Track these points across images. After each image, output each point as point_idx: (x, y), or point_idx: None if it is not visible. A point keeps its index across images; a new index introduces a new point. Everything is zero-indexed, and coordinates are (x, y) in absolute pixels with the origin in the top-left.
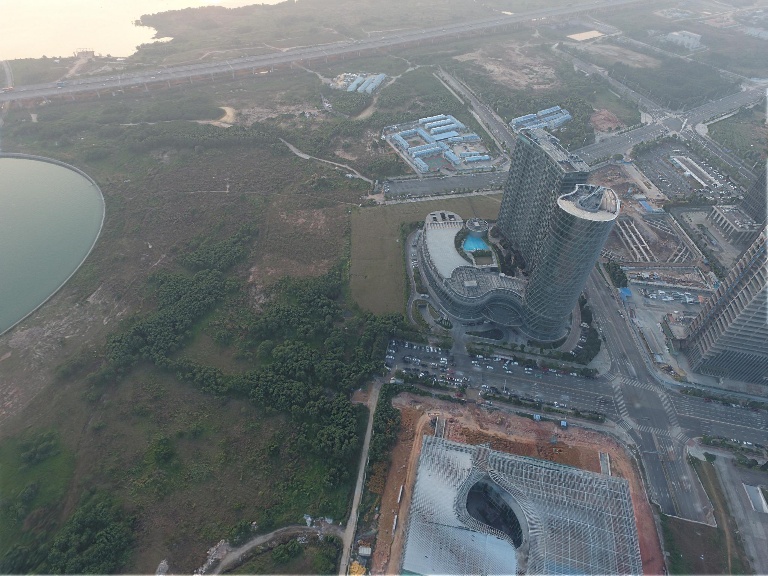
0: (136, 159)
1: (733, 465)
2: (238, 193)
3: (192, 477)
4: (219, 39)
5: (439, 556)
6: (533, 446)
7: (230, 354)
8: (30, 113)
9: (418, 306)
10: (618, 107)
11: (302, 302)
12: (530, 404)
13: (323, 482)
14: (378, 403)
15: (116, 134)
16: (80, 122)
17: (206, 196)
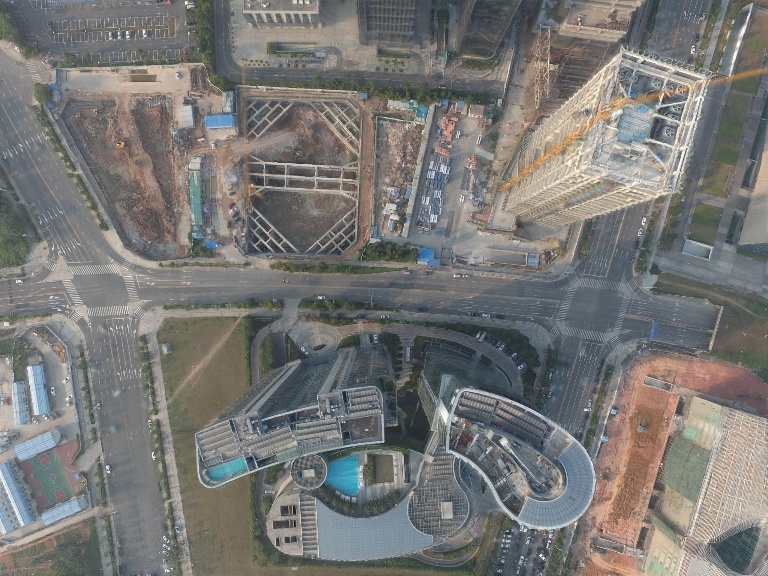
0: None
1: (664, 251)
2: None
3: None
4: None
5: None
6: (634, 451)
7: None
8: None
9: (433, 549)
10: None
11: None
12: (588, 441)
13: None
14: None
15: None
16: None
17: None
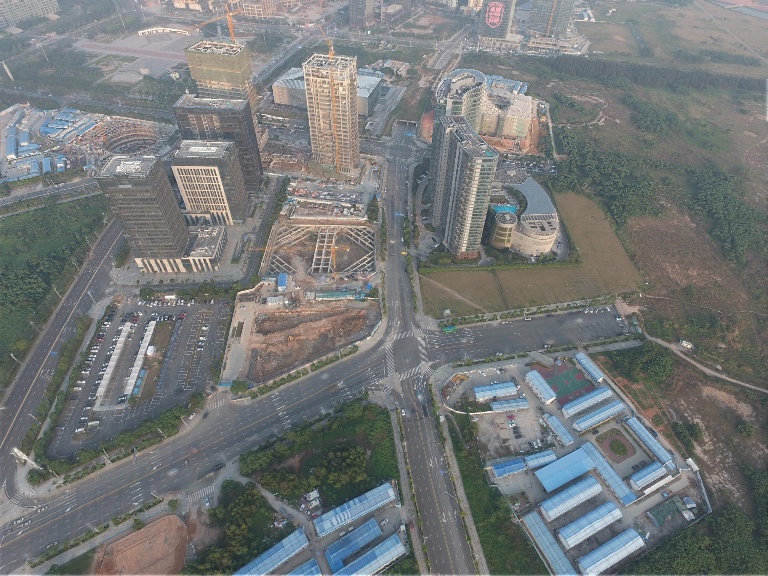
0: None
1: None
2: None
3: None
4: None
5: (519, 97)
6: None
7: (656, 176)
8: None
9: None
10: None
11: None
12: None
13: None
14: None
15: None
16: None
17: None
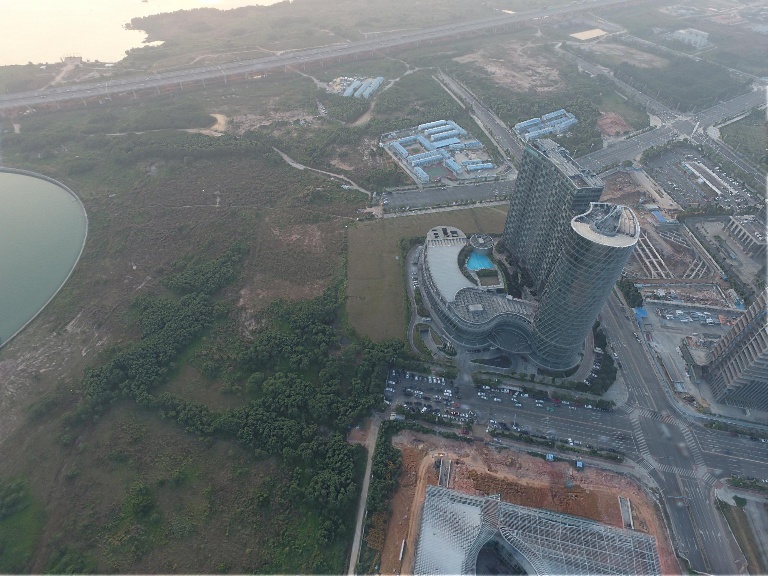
0: (122, 172)
1: (766, 510)
2: (228, 207)
3: (173, 533)
4: (211, 42)
5: None
6: (547, 491)
7: (217, 388)
8: (13, 123)
9: (419, 331)
10: (625, 110)
11: (295, 328)
12: (542, 442)
13: (317, 538)
14: (377, 443)
15: (102, 145)
16: (64, 132)
17: (195, 211)
